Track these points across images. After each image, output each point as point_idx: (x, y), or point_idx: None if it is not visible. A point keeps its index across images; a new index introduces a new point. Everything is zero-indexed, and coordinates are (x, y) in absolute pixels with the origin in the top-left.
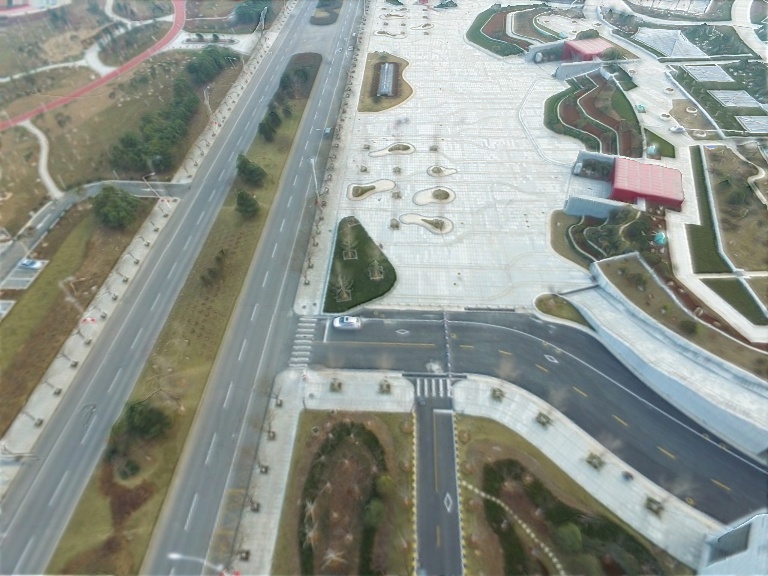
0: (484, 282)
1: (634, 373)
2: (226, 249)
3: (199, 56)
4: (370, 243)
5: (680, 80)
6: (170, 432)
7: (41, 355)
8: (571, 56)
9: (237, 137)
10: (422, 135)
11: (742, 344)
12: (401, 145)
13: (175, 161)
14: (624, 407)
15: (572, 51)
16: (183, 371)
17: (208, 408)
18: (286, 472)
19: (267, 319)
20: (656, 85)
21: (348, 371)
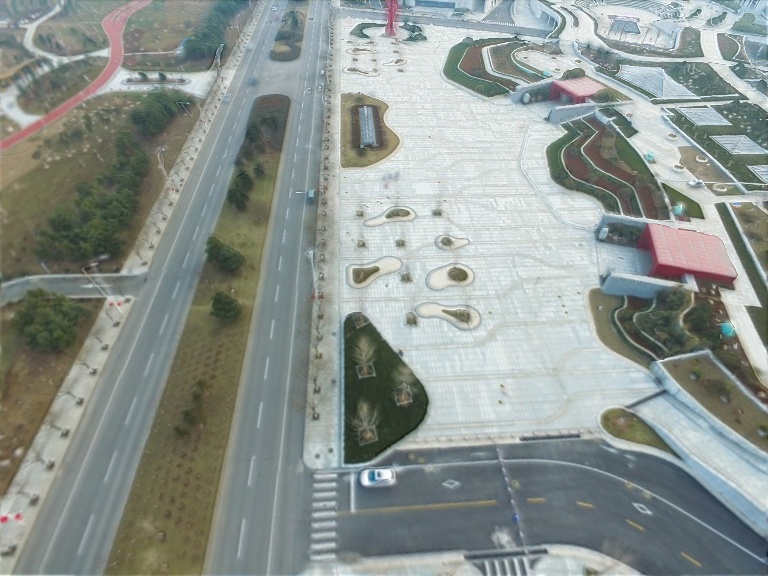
0: (534, 396)
1: (744, 521)
2: (203, 372)
3: (145, 102)
4: (387, 350)
5: (680, 124)
6: None
7: None
8: (559, 96)
9: (200, 205)
10: (420, 195)
11: None
12: (399, 210)
13: (125, 246)
14: None
15: (562, 92)
16: None
17: None
18: None
19: (270, 481)
20: (656, 130)
21: (392, 559)
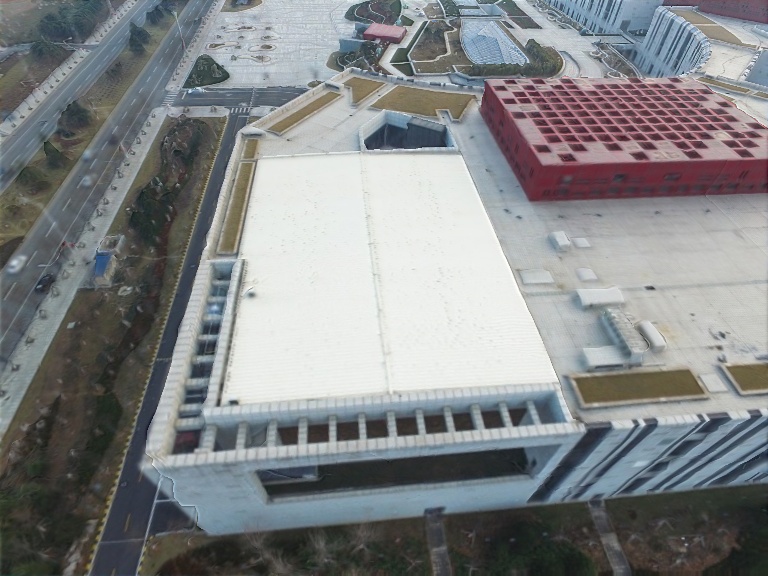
0: (282, 78)
1: None
2: (123, 68)
3: None
4: (216, 64)
5: None
6: (91, 123)
7: (9, 106)
8: None
9: None
10: (262, 23)
11: None
12: (247, 27)
13: (86, 30)
14: None
15: None
16: (98, 108)
17: (113, 119)
18: (156, 134)
19: (149, 92)
20: None
21: (194, 107)
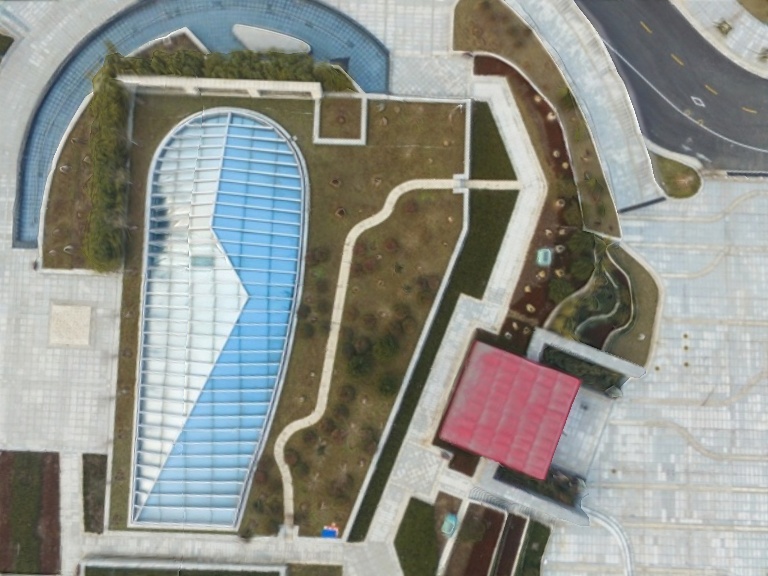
0: (763, 221)
1: None
2: None
3: None
4: None
5: None
6: None
7: None
8: None
9: None
10: None
11: (521, 71)
12: None
13: None
14: (637, 41)
15: None
16: None
17: None
18: None
19: None
20: None
21: None
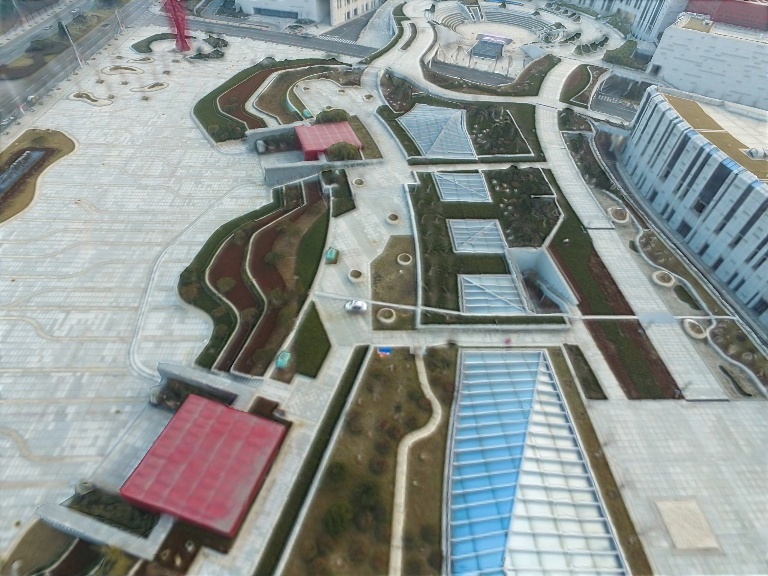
0: None
1: None
2: None
3: None
4: None
5: (416, 199)
6: None
7: None
8: None
9: None
10: None
11: None
12: None
13: None
14: None
15: None
16: None
17: None
18: None
19: None
20: (383, 206)
21: None
